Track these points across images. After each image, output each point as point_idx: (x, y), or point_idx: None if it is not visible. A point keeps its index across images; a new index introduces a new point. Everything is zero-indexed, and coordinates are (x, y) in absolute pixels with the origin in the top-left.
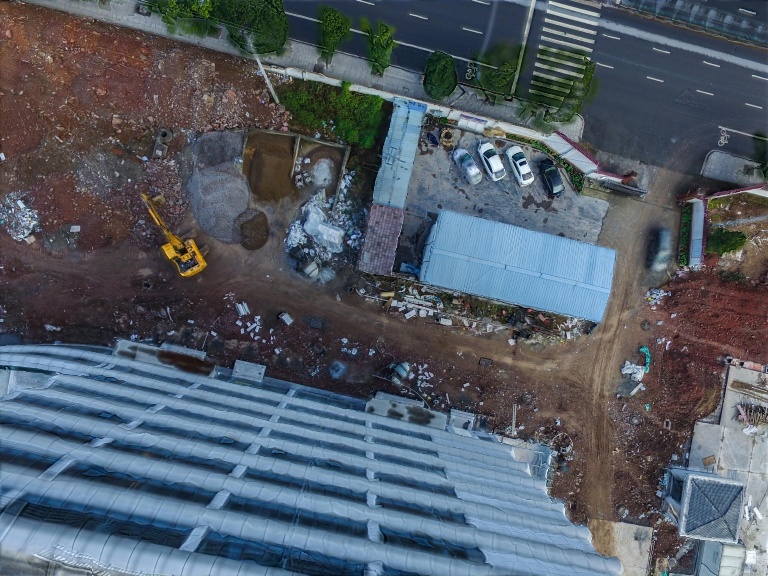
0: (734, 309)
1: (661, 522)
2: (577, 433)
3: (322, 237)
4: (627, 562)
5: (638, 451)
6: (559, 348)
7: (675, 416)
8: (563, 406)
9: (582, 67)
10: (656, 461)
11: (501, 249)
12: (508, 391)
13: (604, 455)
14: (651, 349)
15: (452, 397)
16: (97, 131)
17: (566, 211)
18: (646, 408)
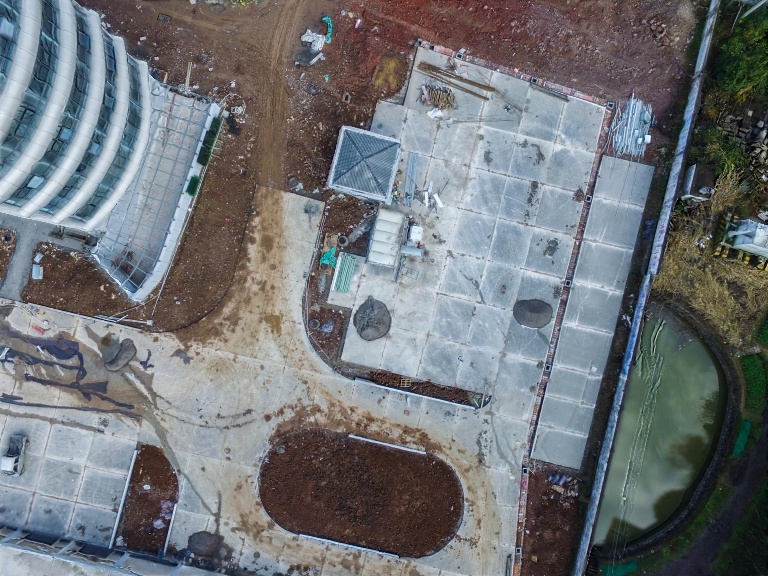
0: None
1: (334, 198)
2: (252, 97)
3: None
4: (295, 234)
5: (310, 118)
6: (240, 11)
7: (354, 89)
8: (240, 70)
9: None
10: (331, 132)
11: None
12: (184, 48)
13: (278, 122)
14: (334, 20)
15: (128, 49)
16: None
17: None
18: (325, 79)
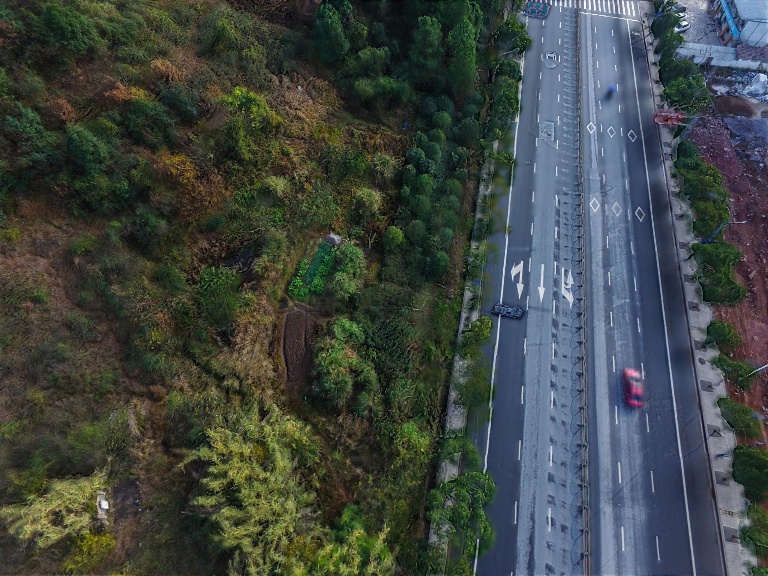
0: None
1: None
2: None
3: (766, 81)
4: None
5: None
6: None
7: None
8: None
9: (613, 1)
10: None
11: (750, 1)
12: None
13: None
14: None
15: None
16: (759, 186)
17: (688, 8)
18: None
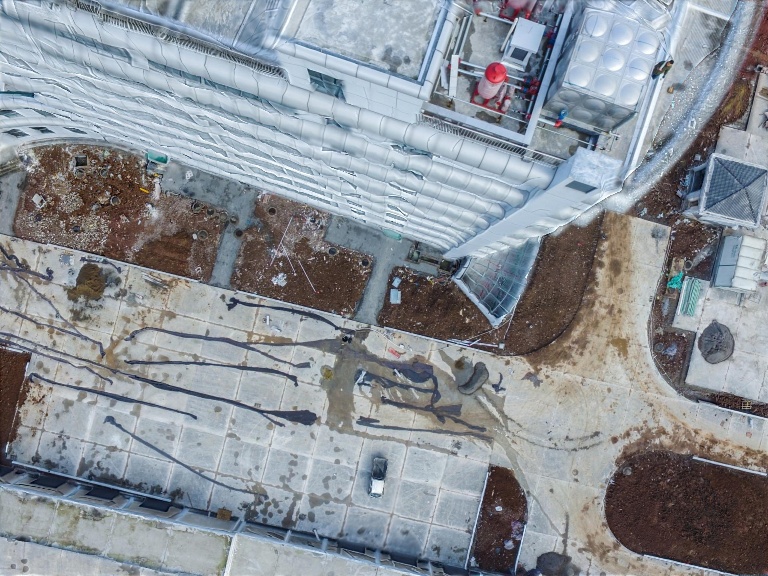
0: (767, 7)
1: (680, 223)
2: None
3: None
4: (642, 259)
5: (661, 144)
6: None
7: (701, 115)
8: None
9: None
10: (678, 158)
11: None
12: None
13: None
14: None
15: None
16: None
17: None
18: (671, 105)
